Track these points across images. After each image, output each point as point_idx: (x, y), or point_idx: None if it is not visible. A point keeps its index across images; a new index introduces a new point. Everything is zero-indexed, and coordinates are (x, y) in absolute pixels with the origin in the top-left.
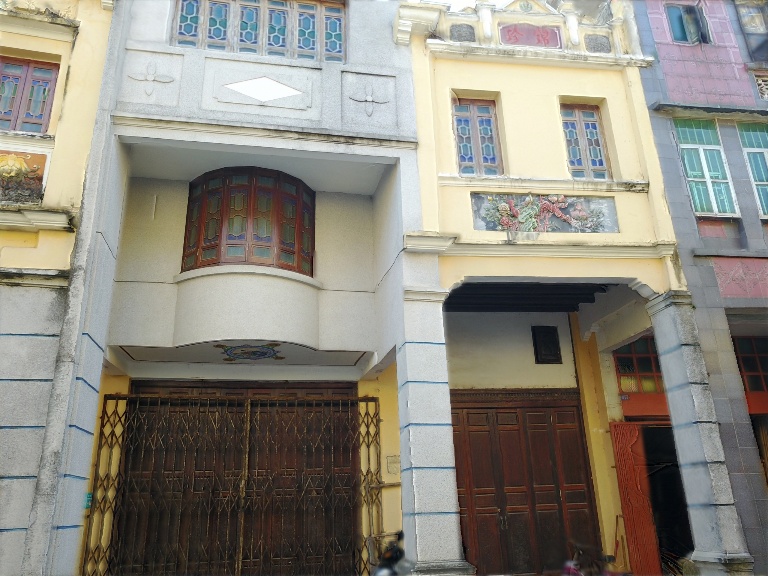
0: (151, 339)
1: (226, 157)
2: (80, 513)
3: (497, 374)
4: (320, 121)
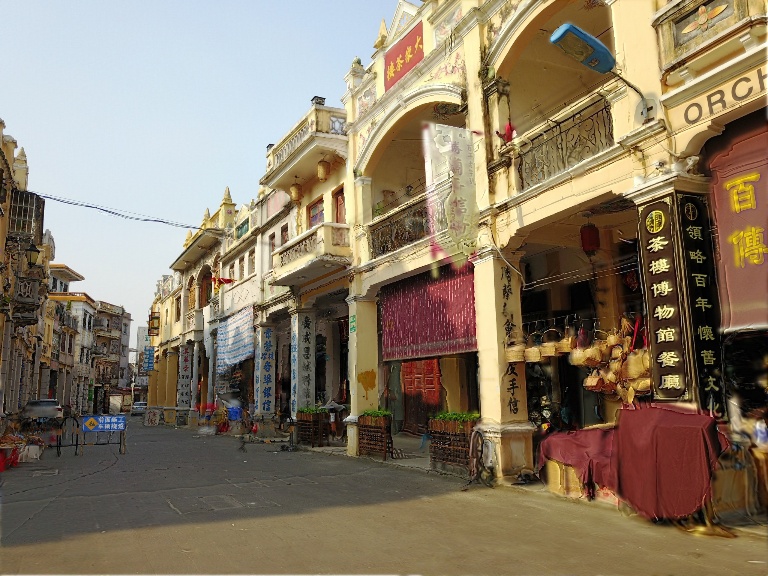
0: None
1: None
2: None
3: None
4: None
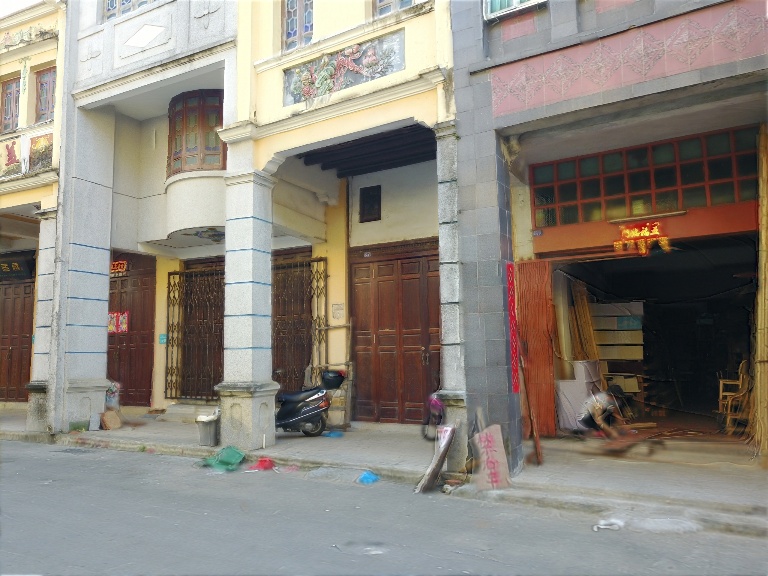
0: (157, 235)
1: (152, 95)
2: (97, 345)
3: (427, 223)
4: (175, 49)
